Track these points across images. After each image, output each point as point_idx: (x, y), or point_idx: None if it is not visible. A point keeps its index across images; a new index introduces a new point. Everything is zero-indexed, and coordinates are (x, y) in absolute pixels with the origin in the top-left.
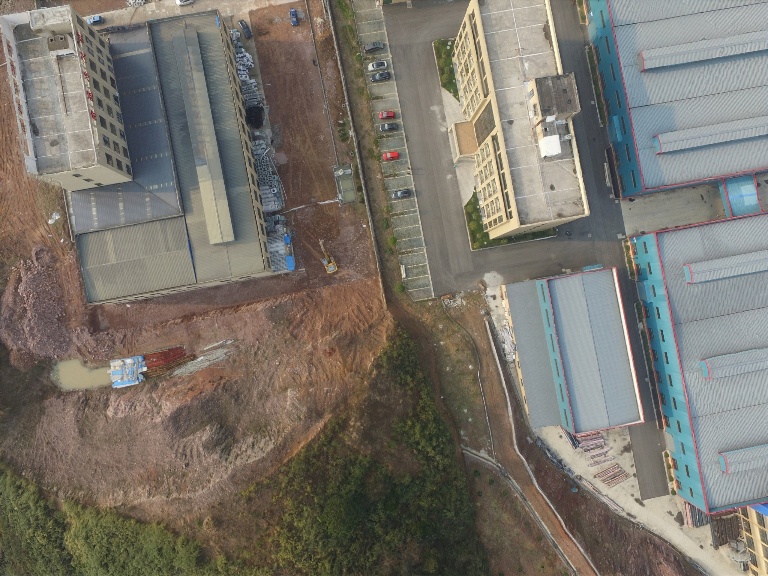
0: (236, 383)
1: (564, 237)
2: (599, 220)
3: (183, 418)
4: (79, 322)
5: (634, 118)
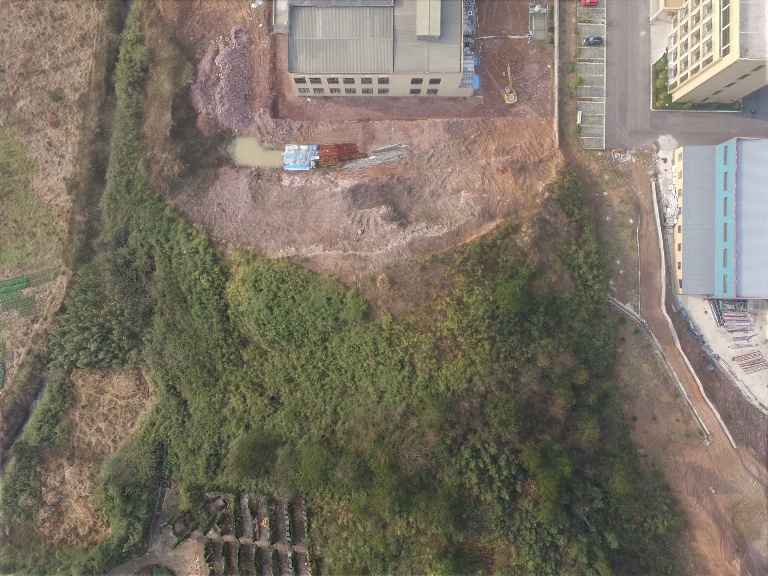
0: (409, 179)
1: (748, 114)
2: None
3: (361, 193)
4: (263, 104)
5: None
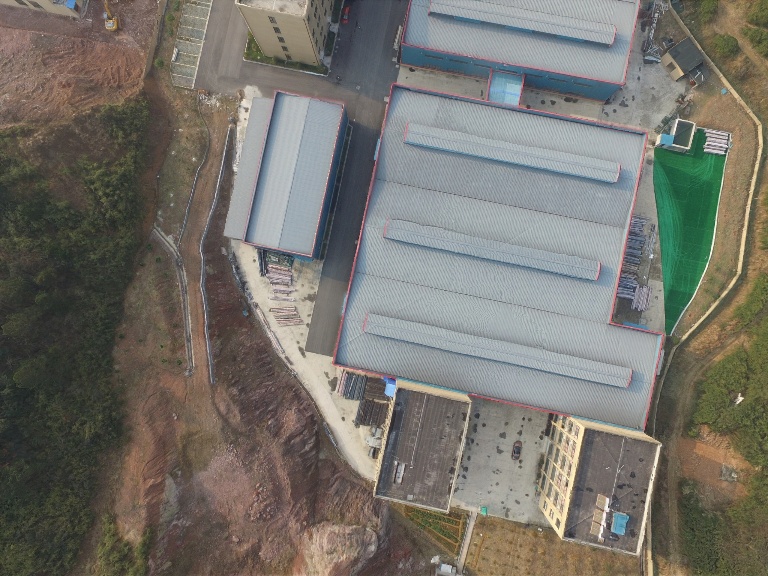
0: None
1: (333, 80)
2: (373, 77)
3: None
4: None
5: None
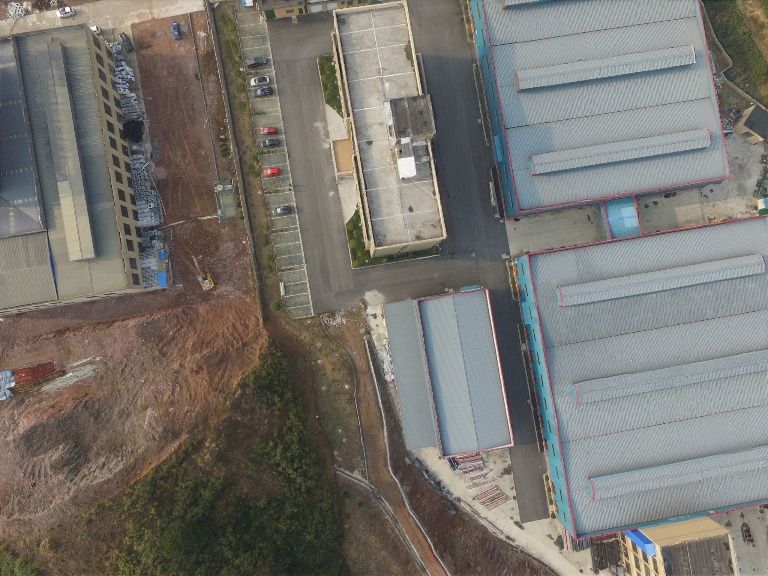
0: (99, 401)
1: (447, 256)
2: (483, 240)
3: (37, 436)
4: None
5: (511, 138)
